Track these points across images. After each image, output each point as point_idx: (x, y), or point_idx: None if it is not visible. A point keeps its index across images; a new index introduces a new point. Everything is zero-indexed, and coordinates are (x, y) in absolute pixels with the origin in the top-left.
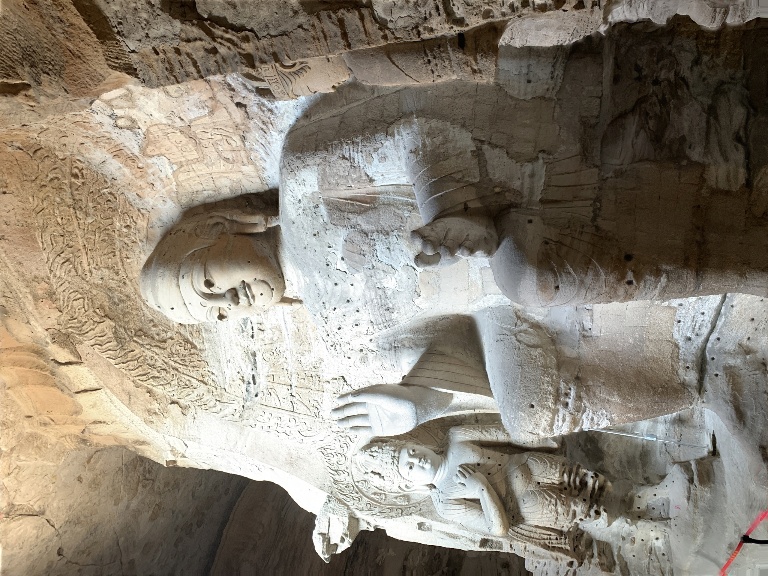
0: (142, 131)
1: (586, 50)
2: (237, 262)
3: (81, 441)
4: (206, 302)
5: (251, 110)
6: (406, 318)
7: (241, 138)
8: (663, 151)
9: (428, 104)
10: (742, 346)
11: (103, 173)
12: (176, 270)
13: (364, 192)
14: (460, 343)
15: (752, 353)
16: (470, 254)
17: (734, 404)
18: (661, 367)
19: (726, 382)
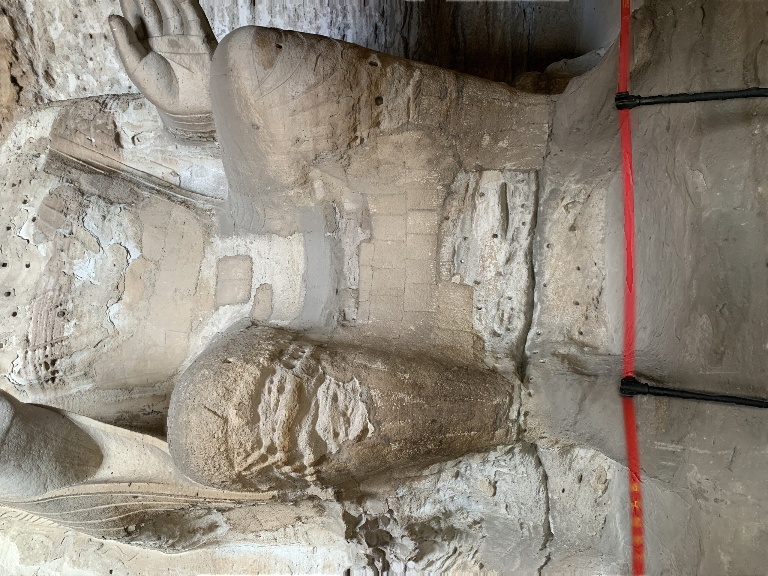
0: None
1: None
2: None
3: None
4: None
5: (25, 96)
6: (86, 344)
7: None
8: None
9: None
10: (574, 341)
11: None
12: None
13: (105, 163)
14: None
15: (591, 347)
16: None
17: (575, 372)
18: (457, 353)
19: (558, 360)
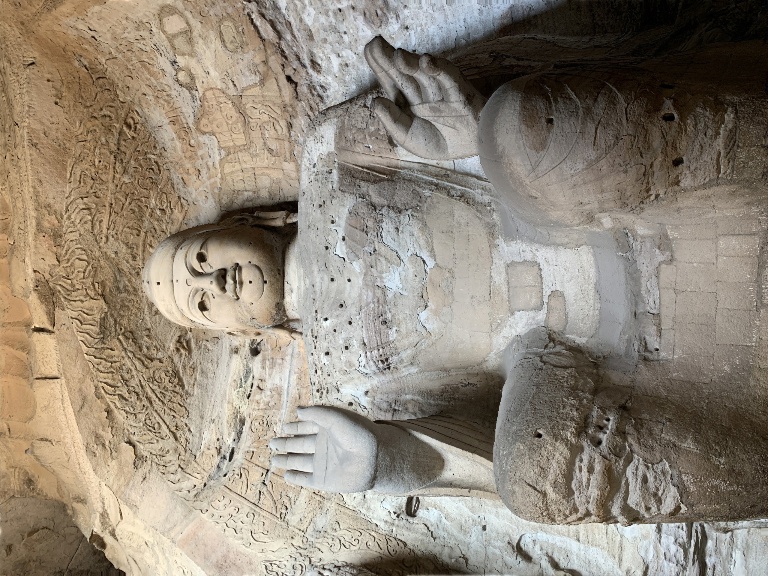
0: (199, 95)
1: (661, 20)
2: (238, 241)
3: (27, 481)
4: (192, 279)
5: (301, 90)
6: (408, 345)
7: (288, 125)
8: (745, 39)
9: (463, 53)
10: None
11: (156, 138)
12: (179, 242)
13: (385, 164)
14: (480, 414)
15: None
16: (430, 64)
17: None
18: None
19: None
